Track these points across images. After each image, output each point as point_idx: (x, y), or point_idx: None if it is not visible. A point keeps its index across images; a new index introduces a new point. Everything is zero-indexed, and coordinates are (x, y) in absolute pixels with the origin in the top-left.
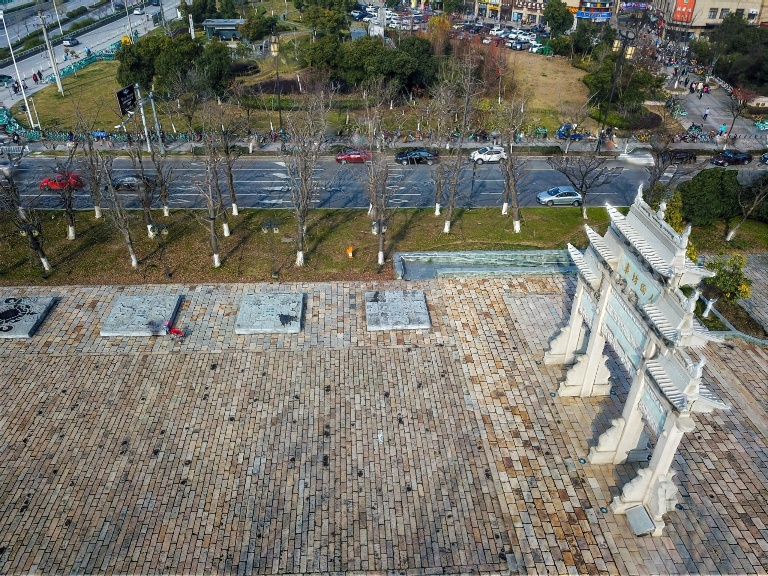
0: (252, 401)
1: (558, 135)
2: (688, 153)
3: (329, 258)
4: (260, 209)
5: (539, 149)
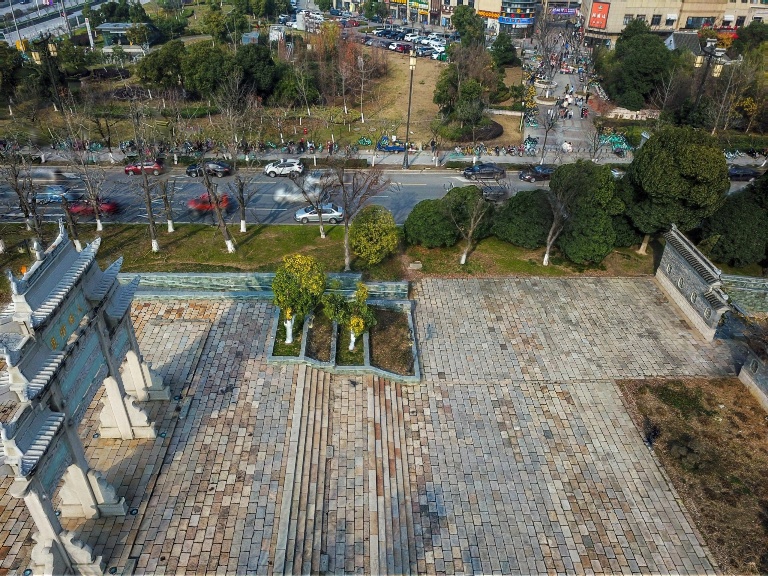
0: None
1: (377, 147)
2: (495, 168)
3: (5, 278)
4: None
5: None
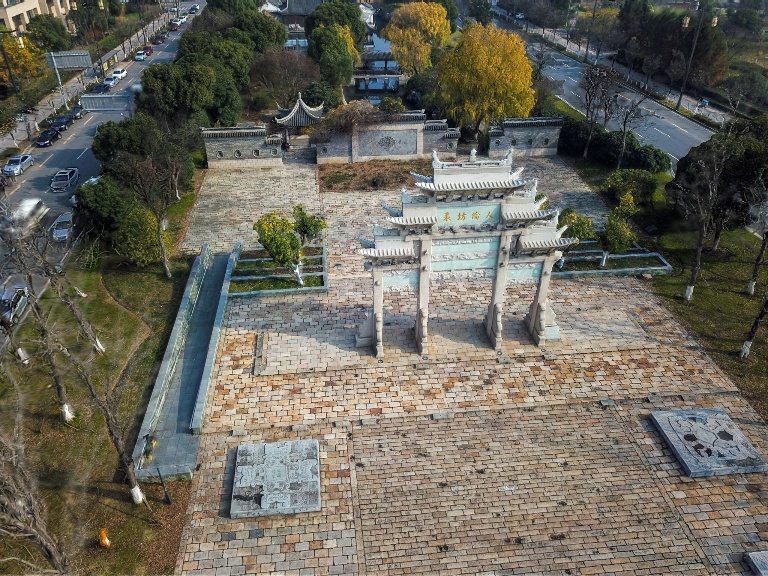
0: None
1: None
2: None
3: None
4: None
5: None
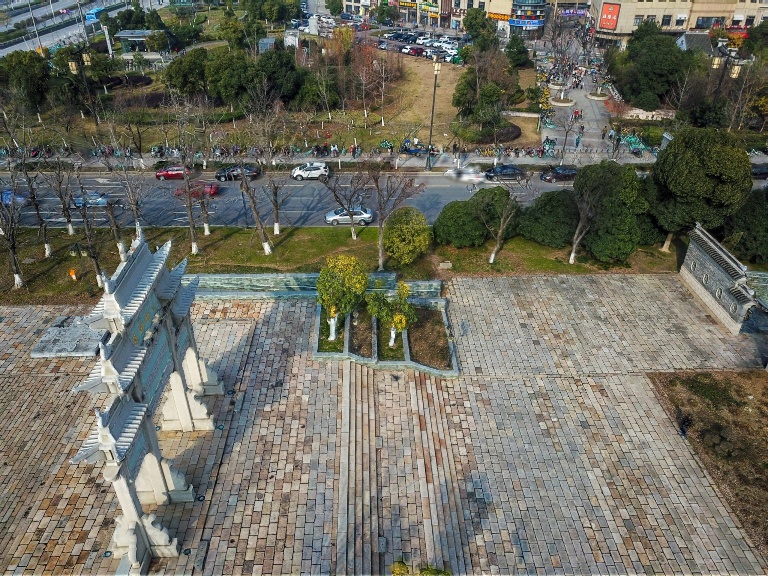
0: None
1: None
2: (516, 169)
3: (54, 280)
4: (37, 228)
5: None
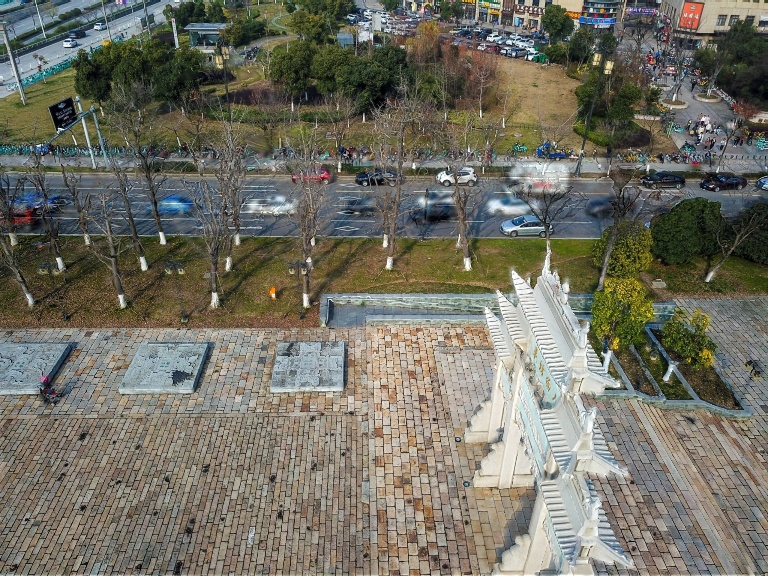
0: (113, 484)
1: (537, 154)
2: (676, 176)
3: (250, 299)
4: (193, 237)
5: (514, 170)
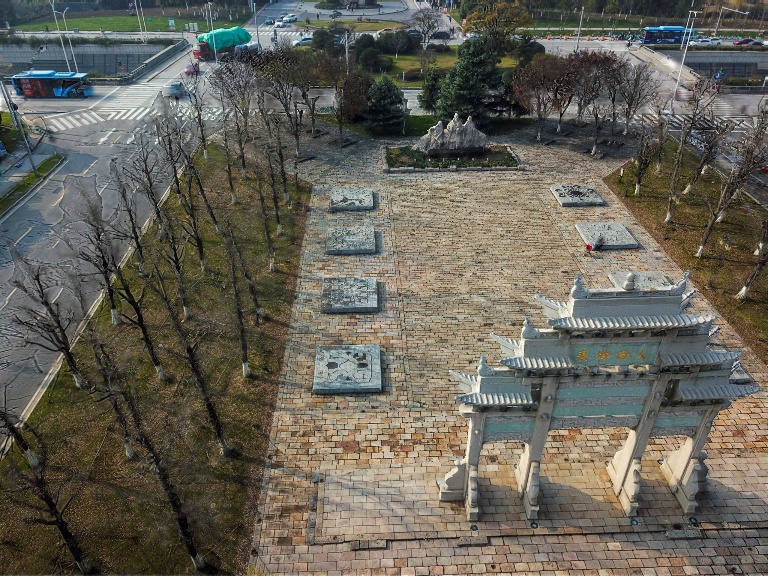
0: (536, 291)
1: None
2: None
3: None
4: None
5: None
